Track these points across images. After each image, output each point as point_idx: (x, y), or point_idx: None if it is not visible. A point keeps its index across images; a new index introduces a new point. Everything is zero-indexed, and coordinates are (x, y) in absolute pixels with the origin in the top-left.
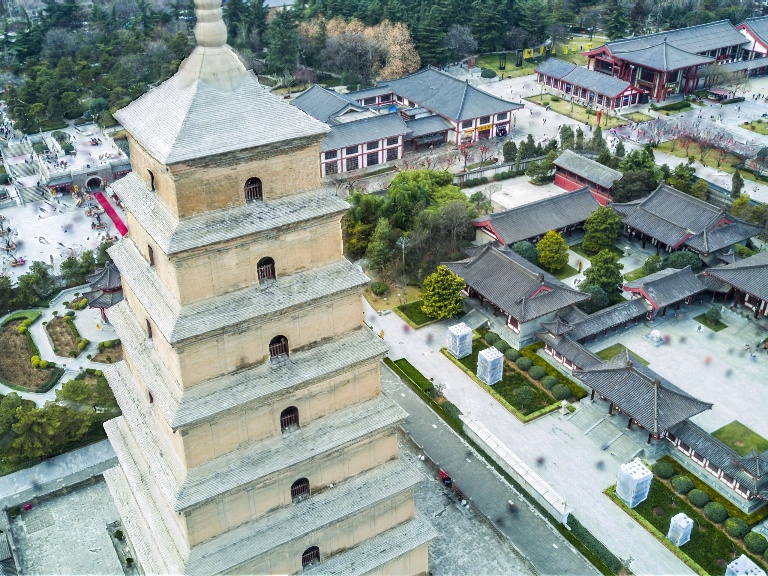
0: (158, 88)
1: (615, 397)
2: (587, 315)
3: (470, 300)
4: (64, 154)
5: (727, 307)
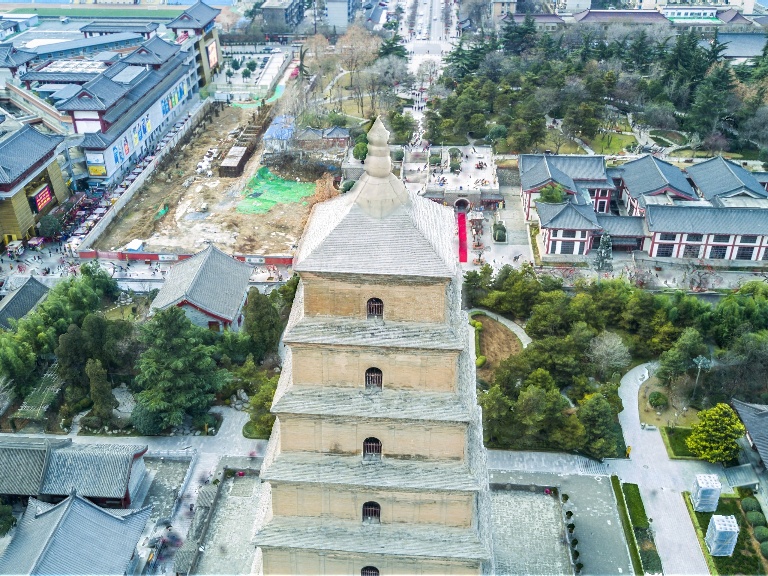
0: (342, 195)
1: None
2: None
3: (751, 452)
4: (449, 171)
5: None
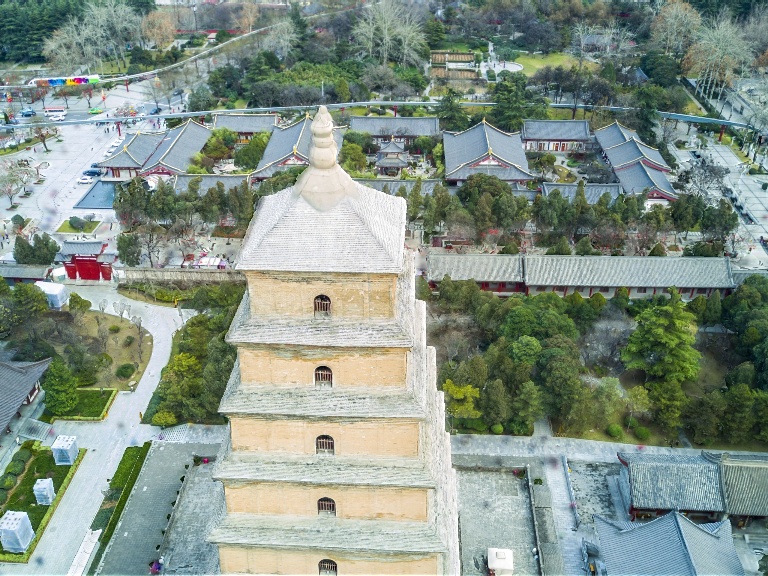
0: (365, 222)
1: None
2: None
3: None
4: None
5: None
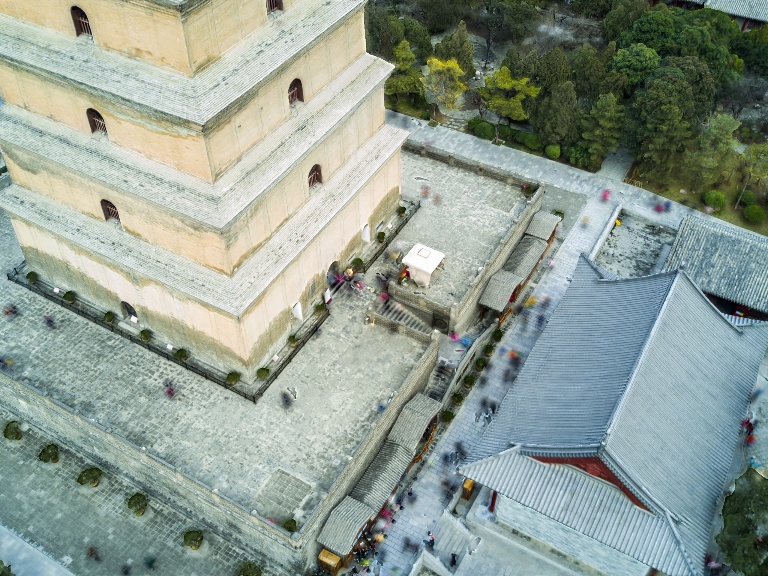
0: None
1: None
2: None
3: None
4: None
5: None
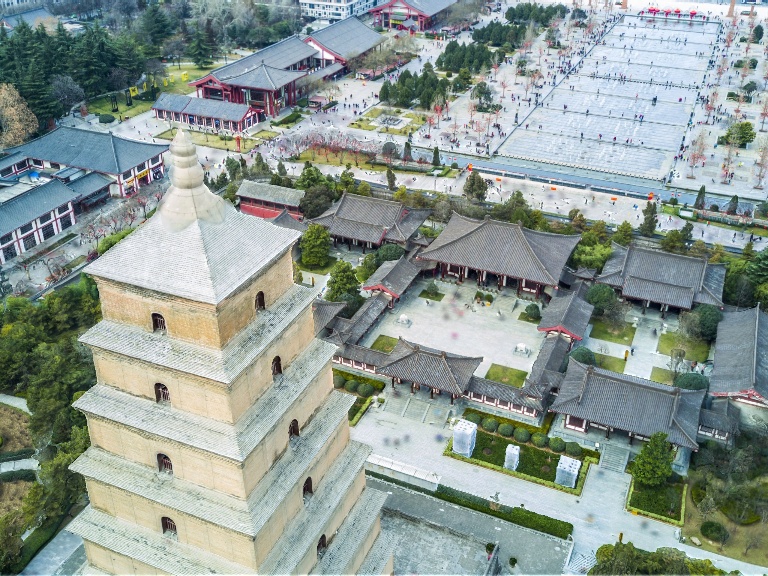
0: (135, 235)
1: (417, 378)
2: (352, 320)
3: None
4: None
5: (438, 280)
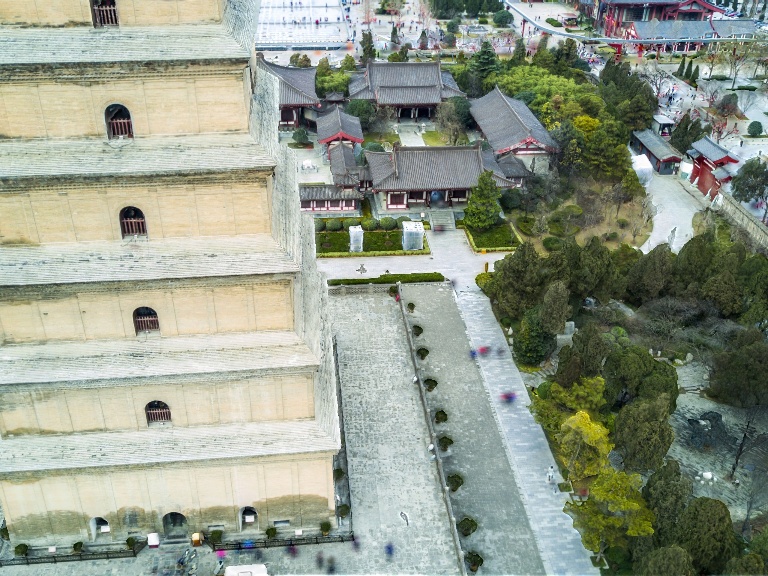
0: None
1: None
2: None
3: None
4: None
5: None
